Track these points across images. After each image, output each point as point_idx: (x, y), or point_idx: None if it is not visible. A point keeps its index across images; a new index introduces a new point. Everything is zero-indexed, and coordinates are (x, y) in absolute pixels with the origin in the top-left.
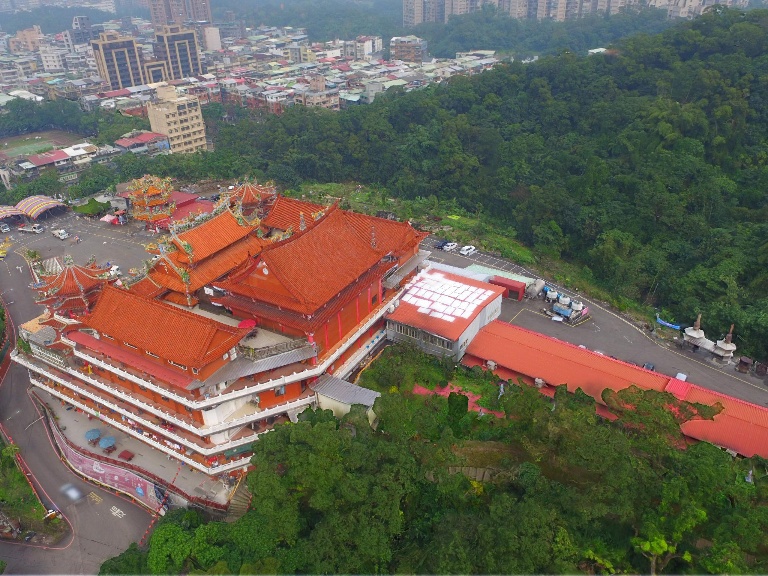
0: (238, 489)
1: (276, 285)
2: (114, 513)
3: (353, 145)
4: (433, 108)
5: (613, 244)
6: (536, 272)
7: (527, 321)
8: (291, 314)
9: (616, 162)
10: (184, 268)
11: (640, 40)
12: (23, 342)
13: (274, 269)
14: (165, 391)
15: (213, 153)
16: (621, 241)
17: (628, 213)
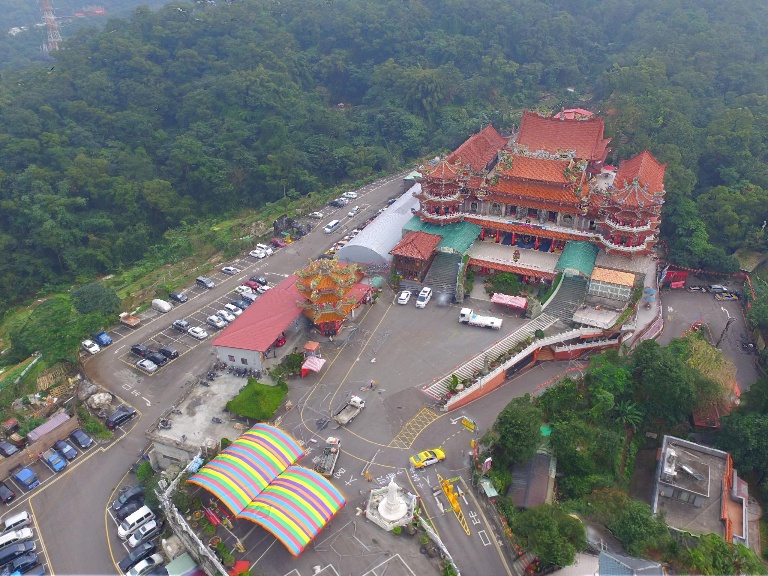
0: None
1: None
2: (672, 310)
3: None
4: (1, 175)
5: None
6: (386, 177)
7: None
8: None
9: (277, 118)
10: None
11: (125, 43)
12: (641, 290)
13: None
14: None
15: (56, 317)
16: None
17: None
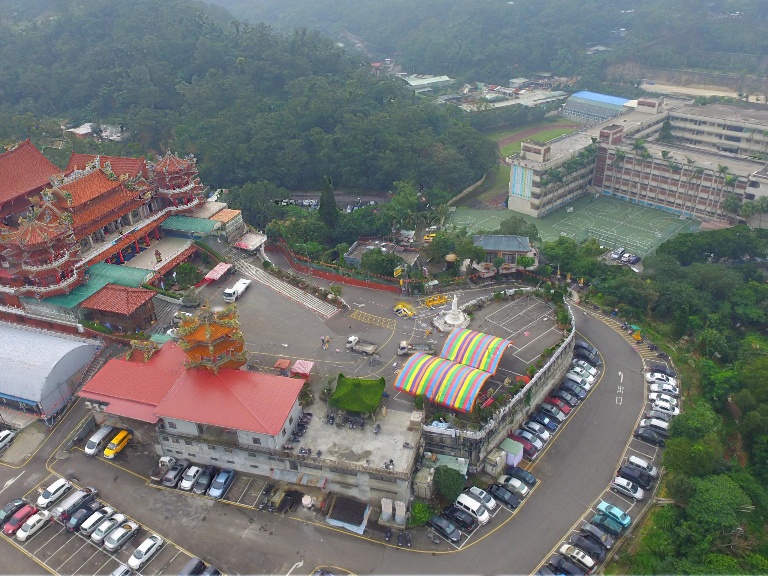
0: None
1: None
2: None
3: None
4: None
5: None
6: None
7: None
8: None
9: None
10: None
11: None
12: None
13: None
14: None
15: None
16: None
17: None
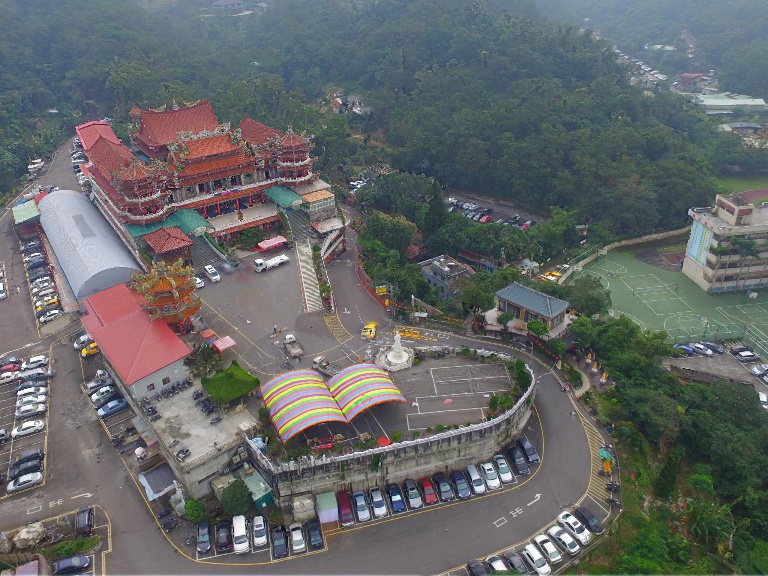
0: None
1: None
2: None
3: None
4: None
5: None
6: None
7: None
8: None
9: None
10: None
11: None
12: None
13: None
14: None
15: None
16: None
17: None
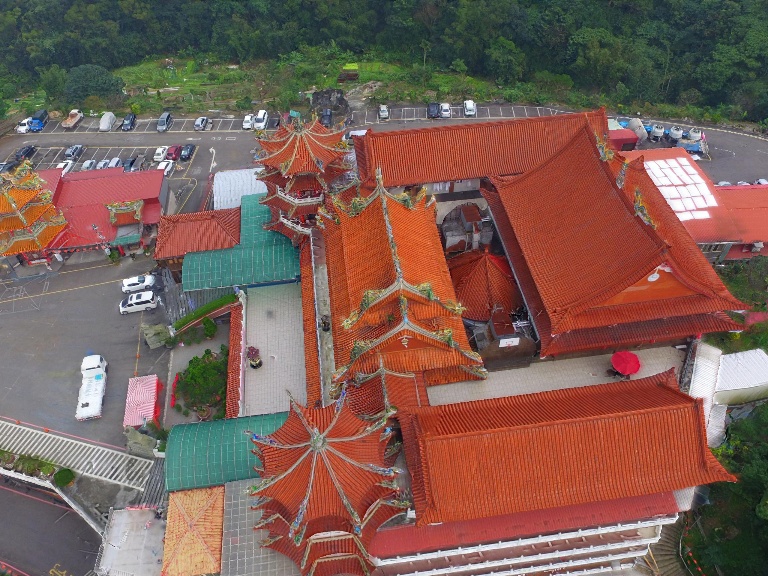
0: (649, 555)
1: (665, 289)
2: None
3: (129, 1)
4: None
5: (599, 46)
6: (567, 108)
7: None
8: (676, 317)
9: None
10: (430, 326)
11: None
12: None
13: (677, 269)
14: (612, 528)
15: None
16: (603, 40)
17: (586, 4)
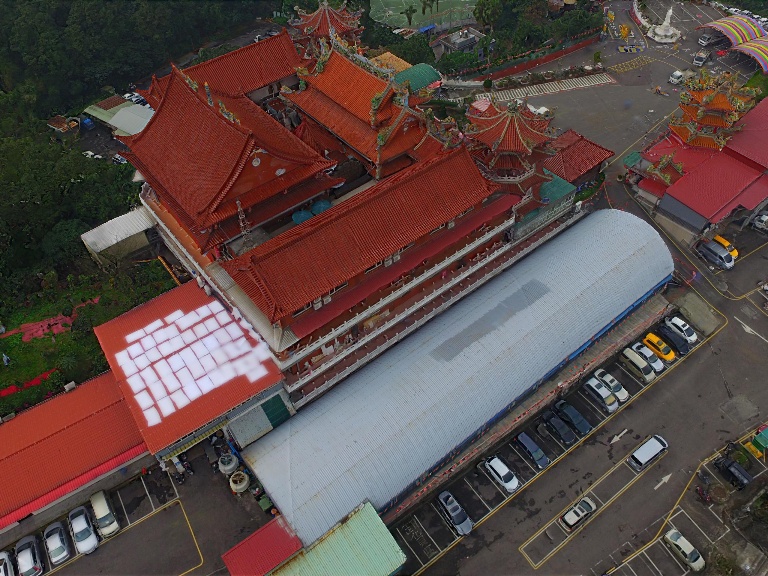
0: None
1: None
2: None
3: None
4: None
5: None
6: None
7: (167, 541)
8: None
9: None
10: None
11: None
12: None
13: None
14: None
15: None
16: None
17: None
